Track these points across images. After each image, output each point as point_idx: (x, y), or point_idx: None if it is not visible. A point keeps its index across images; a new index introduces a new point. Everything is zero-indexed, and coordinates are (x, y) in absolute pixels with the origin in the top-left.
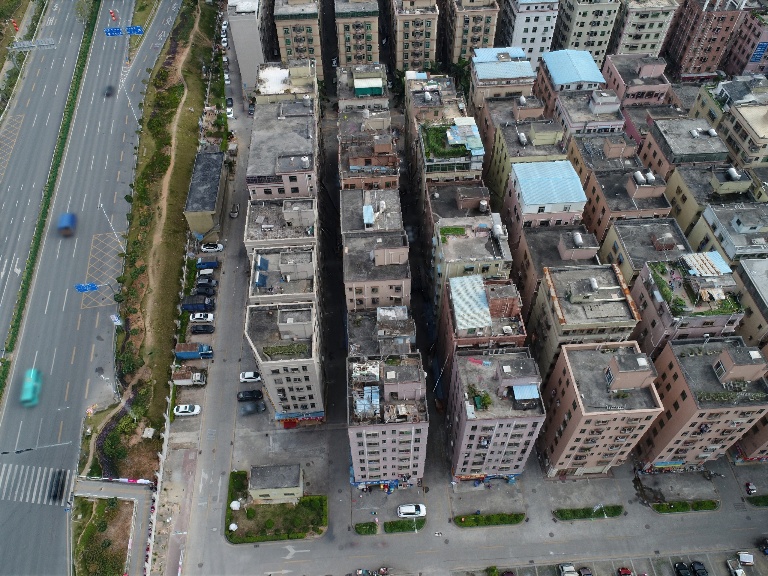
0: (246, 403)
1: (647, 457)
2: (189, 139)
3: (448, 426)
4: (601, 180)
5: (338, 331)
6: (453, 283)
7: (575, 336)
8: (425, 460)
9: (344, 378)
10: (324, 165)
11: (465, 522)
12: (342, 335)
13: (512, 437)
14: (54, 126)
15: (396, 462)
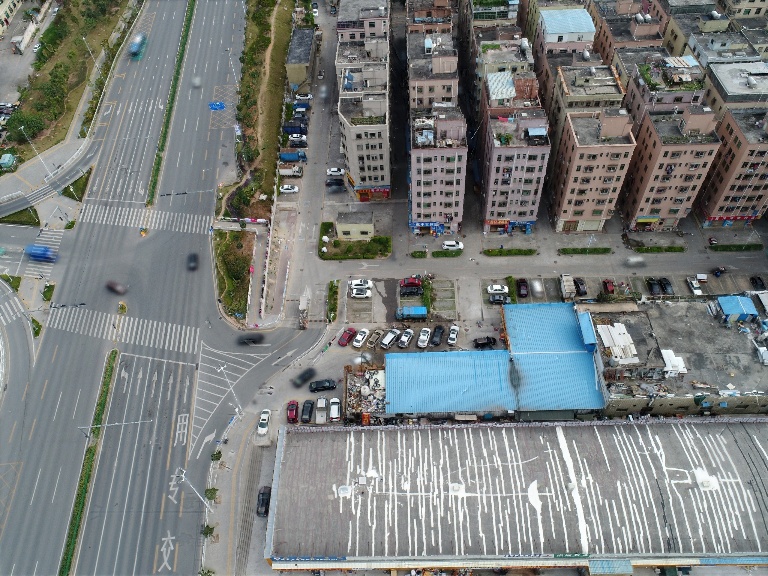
0: None
1: (632, 214)
2: (284, 28)
3: (482, 191)
4: (610, 25)
5: (401, 143)
6: (489, 76)
7: (577, 109)
8: (464, 220)
9: (405, 174)
10: (392, 41)
11: (492, 252)
12: (404, 149)
13: (527, 171)
14: (179, 19)
15: (443, 198)
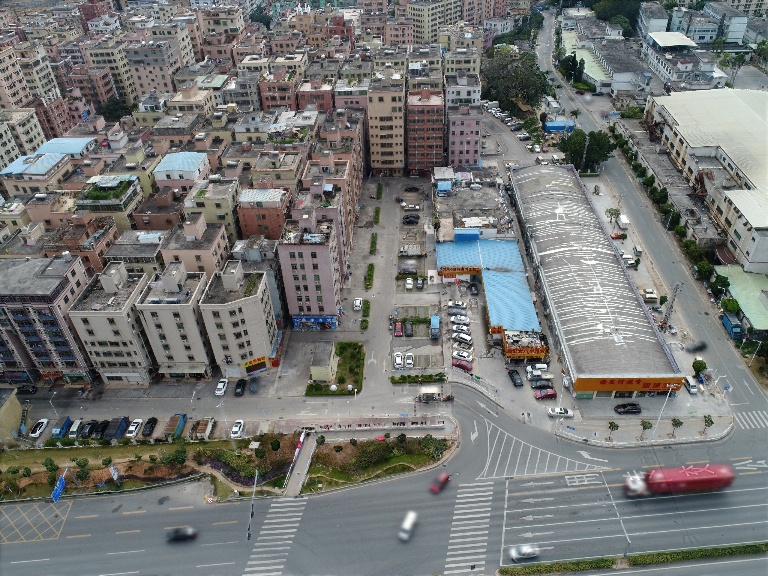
0: (246, 391)
1: None
2: None
3: None
4: None
5: None
6: (243, 200)
7: None
8: None
9: None
10: None
11: (370, 283)
12: None
13: None
14: None
15: (337, 275)
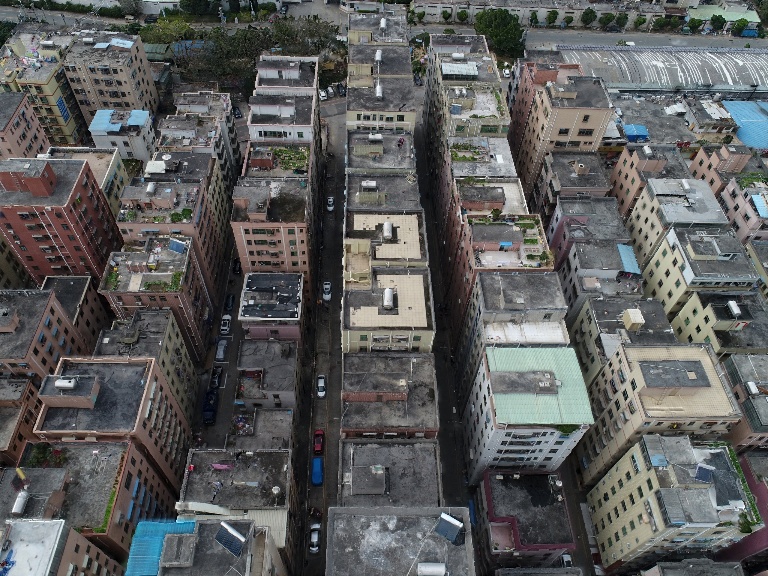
0: None
1: None
2: None
3: None
4: None
5: None
6: None
7: None
8: None
9: None
10: None
11: None
12: None
13: None
14: None
15: None
